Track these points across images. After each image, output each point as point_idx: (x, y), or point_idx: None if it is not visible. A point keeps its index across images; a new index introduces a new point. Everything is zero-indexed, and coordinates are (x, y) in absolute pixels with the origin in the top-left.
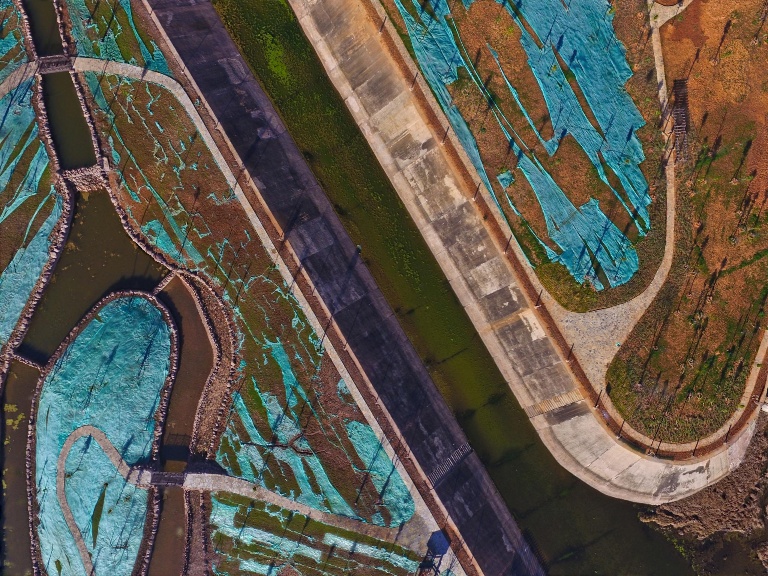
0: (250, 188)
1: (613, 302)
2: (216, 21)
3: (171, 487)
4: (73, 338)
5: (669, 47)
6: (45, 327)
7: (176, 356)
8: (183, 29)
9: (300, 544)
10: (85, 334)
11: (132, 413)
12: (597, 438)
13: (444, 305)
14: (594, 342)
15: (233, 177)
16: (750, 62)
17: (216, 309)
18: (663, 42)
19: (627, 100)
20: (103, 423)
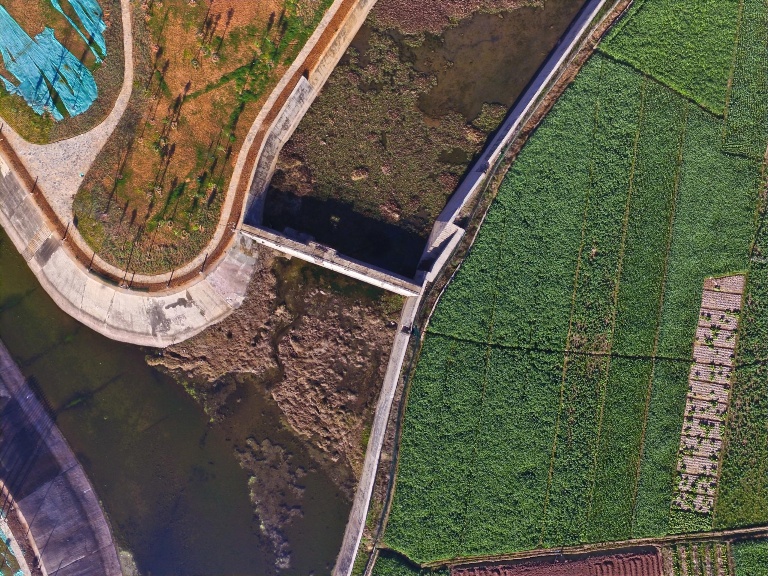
0: None
1: (74, 132)
2: None
3: None
4: None
5: None
6: None
7: None
8: None
9: None
10: None
11: None
12: (72, 273)
13: None
14: (58, 174)
15: None
16: None
17: None
18: None
19: None
20: None
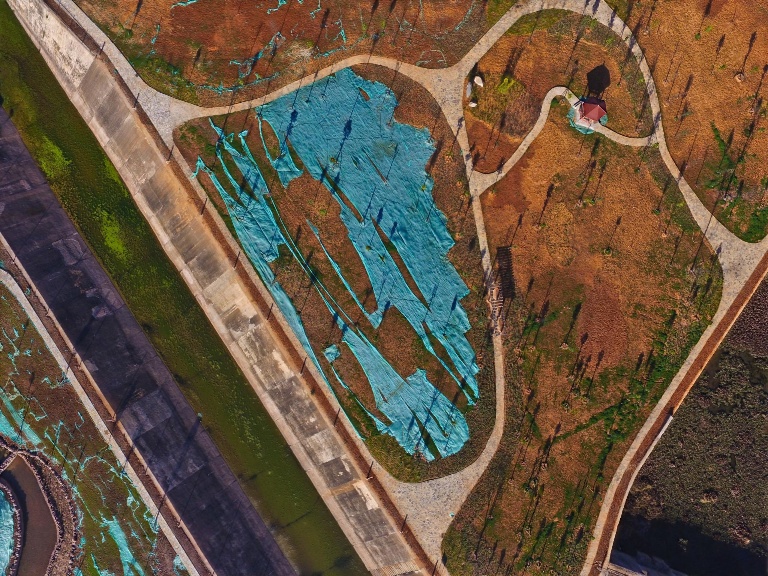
0: (81, 372)
1: (445, 472)
2: (53, 202)
3: None
4: None
5: (490, 214)
6: None
7: (19, 535)
8: (15, 218)
9: None
10: None
11: None
12: None
13: (286, 469)
14: (427, 513)
15: (65, 362)
16: (575, 225)
17: (57, 487)
18: (484, 210)
19: (450, 269)
20: None
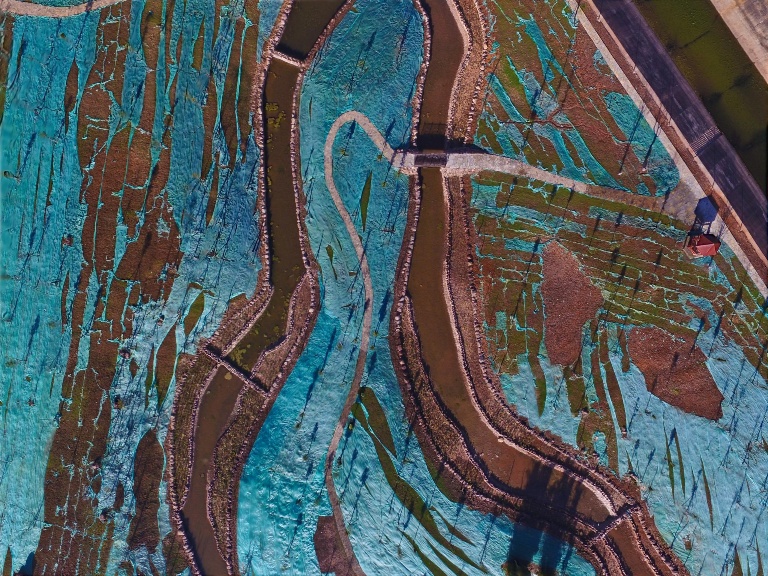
0: None
1: None
2: None
3: (429, 176)
4: (330, 31)
5: None
6: (300, 26)
7: (429, 43)
8: None
9: (565, 219)
10: (342, 25)
11: (393, 97)
12: None
13: None
14: None
15: None
16: None
17: None
18: None
19: None
20: (366, 108)
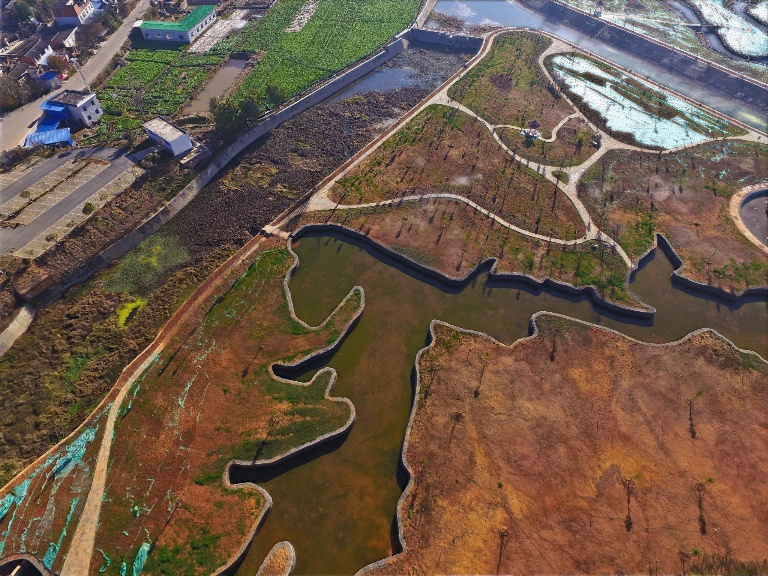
0: None
1: None
2: None
3: None
4: None
5: None
6: None
7: None
8: None
9: None
10: None
11: None
12: None
13: None
14: None
15: None
16: None
17: None
18: None
19: None
20: None
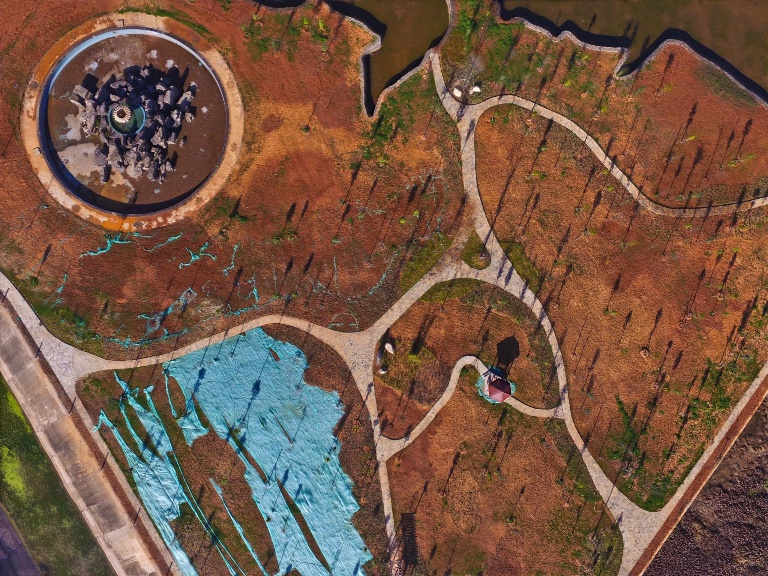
0: None
1: None
2: None
3: None
4: None
5: (396, 480)
6: None
7: None
8: None
9: None
10: None
11: None
12: None
13: None
14: None
15: None
16: (480, 493)
17: None
18: (390, 475)
19: (354, 534)
20: None
